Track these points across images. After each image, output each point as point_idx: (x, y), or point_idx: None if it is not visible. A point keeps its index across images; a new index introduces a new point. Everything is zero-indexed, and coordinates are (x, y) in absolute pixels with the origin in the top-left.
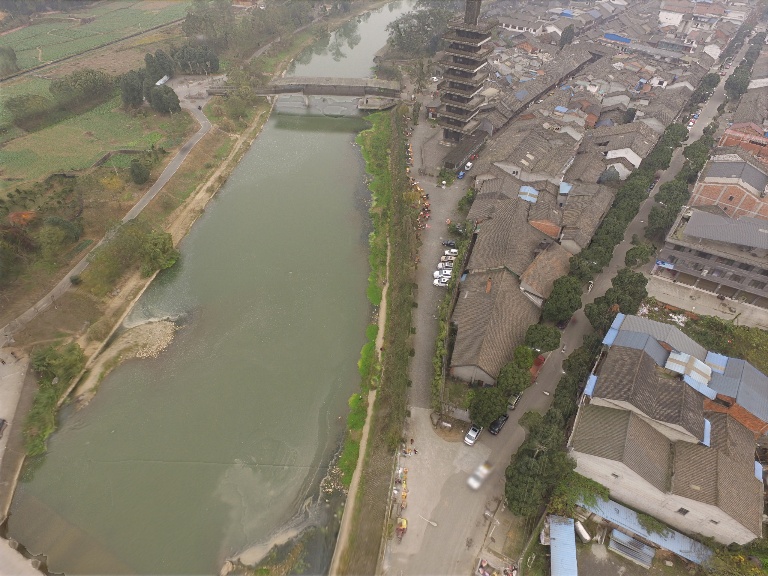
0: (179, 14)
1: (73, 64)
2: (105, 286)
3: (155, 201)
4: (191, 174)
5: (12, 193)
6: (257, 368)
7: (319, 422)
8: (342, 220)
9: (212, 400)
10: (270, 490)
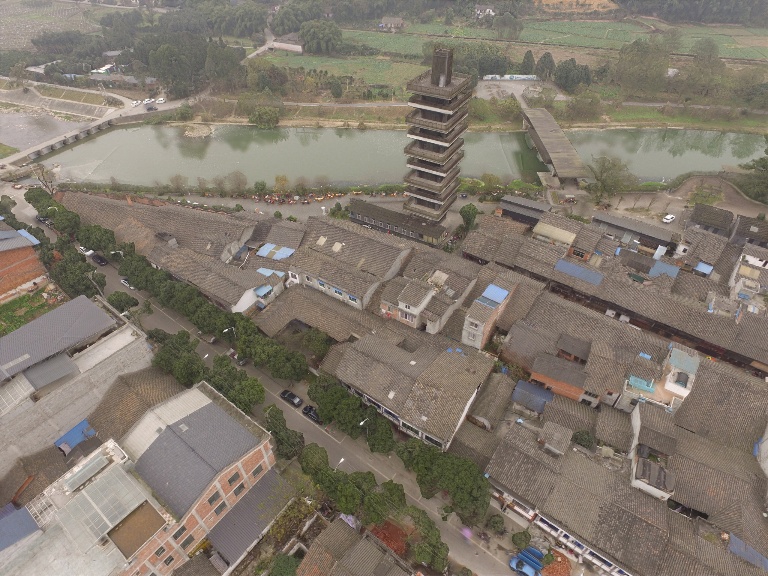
0: (746, 55)
1: (543, 48)
2: (242, 113)
3: (322, 108)
4: (365, 114)
5: (324, 71)
6: (158, 159)
7: (109, 179)
8: (299, 177)
9: (144, 151)
10: (82, 170)
